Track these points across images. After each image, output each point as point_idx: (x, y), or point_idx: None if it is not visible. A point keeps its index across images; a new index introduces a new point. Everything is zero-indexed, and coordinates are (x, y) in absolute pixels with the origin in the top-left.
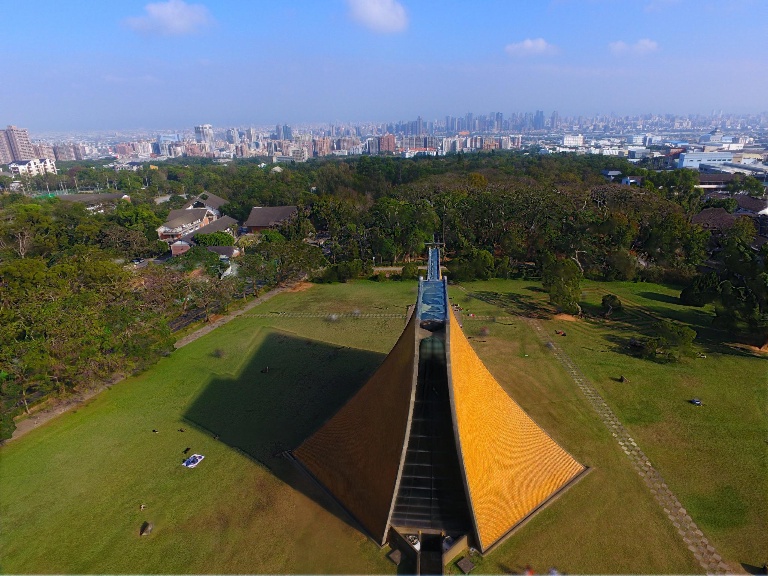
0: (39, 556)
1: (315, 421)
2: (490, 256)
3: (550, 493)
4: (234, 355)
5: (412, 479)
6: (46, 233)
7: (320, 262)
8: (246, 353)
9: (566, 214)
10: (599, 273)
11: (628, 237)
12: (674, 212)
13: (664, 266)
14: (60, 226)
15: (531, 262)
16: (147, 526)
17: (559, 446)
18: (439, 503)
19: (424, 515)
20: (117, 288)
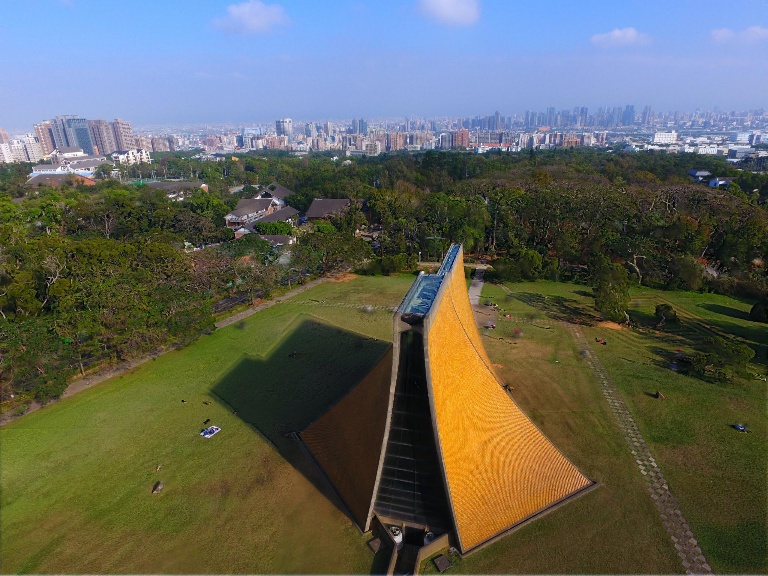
0: (66, 499)
1: (328, 407)
2: (538, 256)
3: (547, 504)
4: (268, 338)
5: (396, 471)
6: (129, 216)
7: (365, 254)
8: (279, 337)
9: (628, 216)
10: (659, 281)
11: (697, 243)
12: (757, 218)
13: (738, 277)
14: (142, 211)
15: (586, 265)
16: (158, 485)
17: (563, 457)
18: (422, 498)
19: (408, 508)
20: (169, 268)
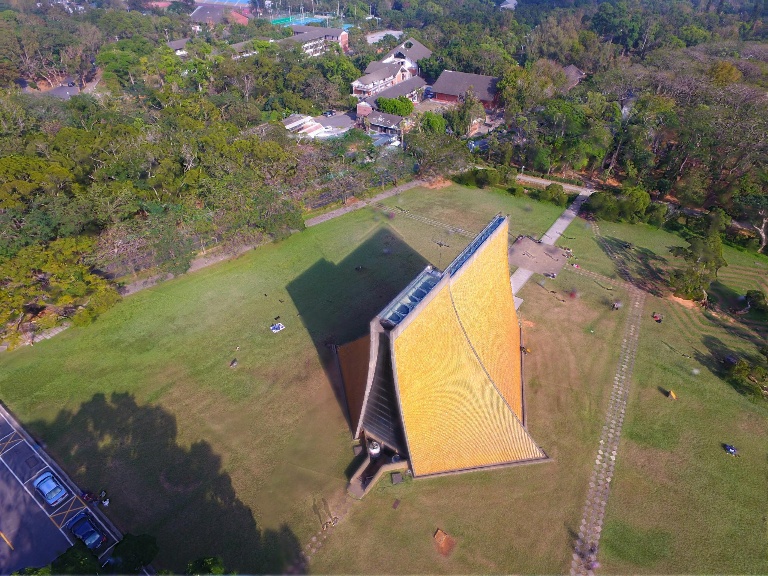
0: (180, 356)
1: (367, 328)
2: (646, 199)
3: (497, 462)
4: (346, 245)
5: (377, 410)
6: (266, 76)
7: (463, 163)
8: (355, 246)
9: None
10: None
11: None
12: None
13: None
14: (278, 69)
15: None
16: (234, 363)
17: (525, 432)
18: (394, 433)
19: (385, 435)
20: (274, 168)
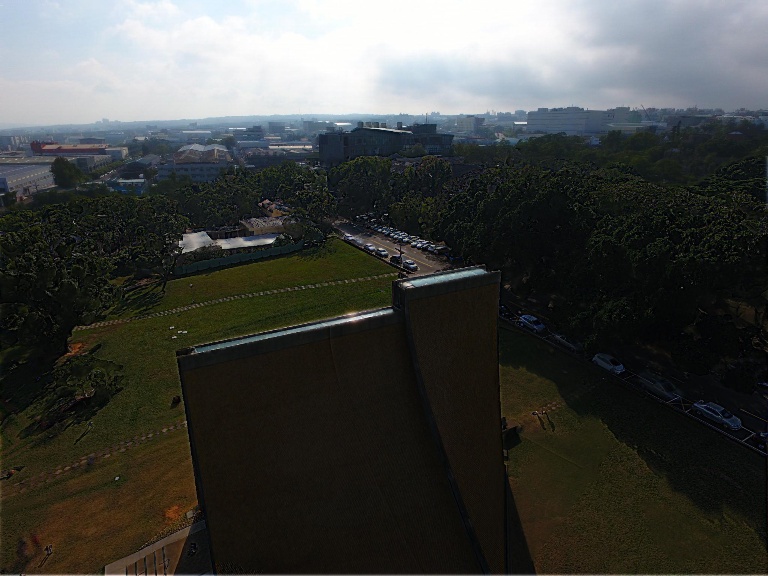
0: None
1: None
2: None
3: None
4: None
5: None
6: None
7: None
8: None
9: None
10: None
11: None
12: None
13: None
14: None
15: None
16: None
17: None
18: None
19: None
20: None
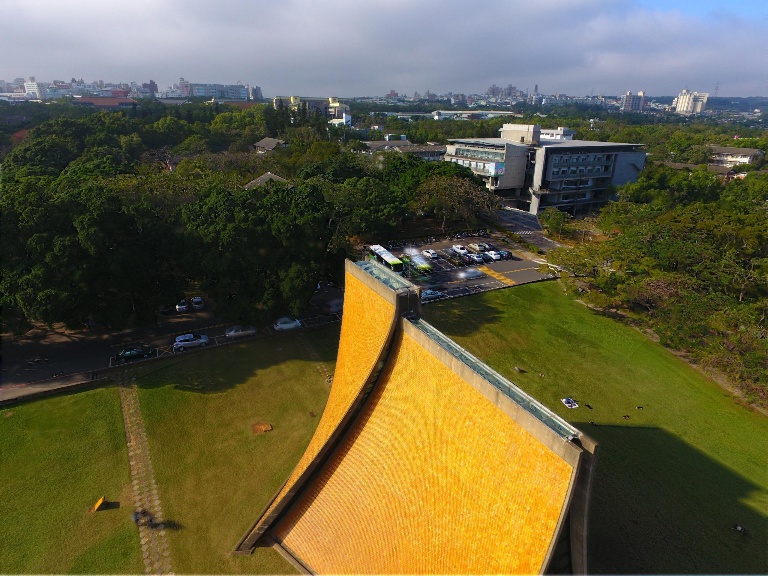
0: None
1: None
2: None
3: None
4: None
5: None
6: None
7: None
8: None
9: None
10: None
11: None
12: None
13: None
14: None
15: None
16: None
17: None
18: None
19: None
20: None
